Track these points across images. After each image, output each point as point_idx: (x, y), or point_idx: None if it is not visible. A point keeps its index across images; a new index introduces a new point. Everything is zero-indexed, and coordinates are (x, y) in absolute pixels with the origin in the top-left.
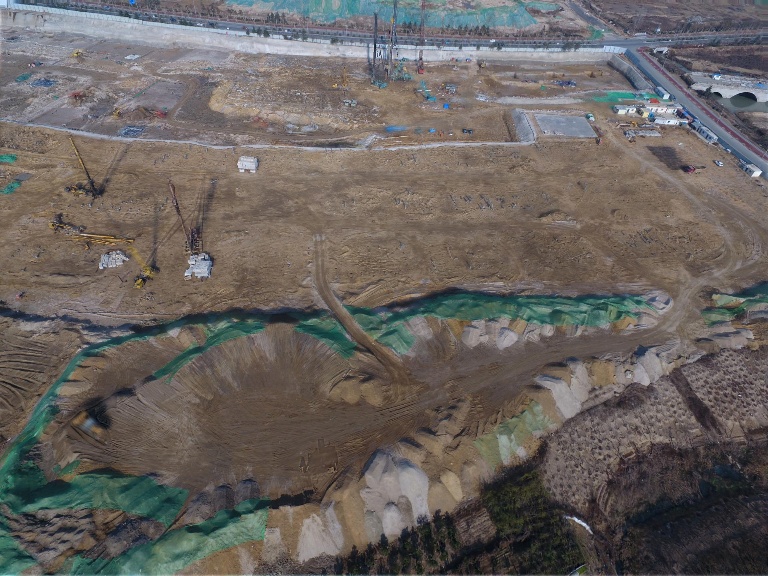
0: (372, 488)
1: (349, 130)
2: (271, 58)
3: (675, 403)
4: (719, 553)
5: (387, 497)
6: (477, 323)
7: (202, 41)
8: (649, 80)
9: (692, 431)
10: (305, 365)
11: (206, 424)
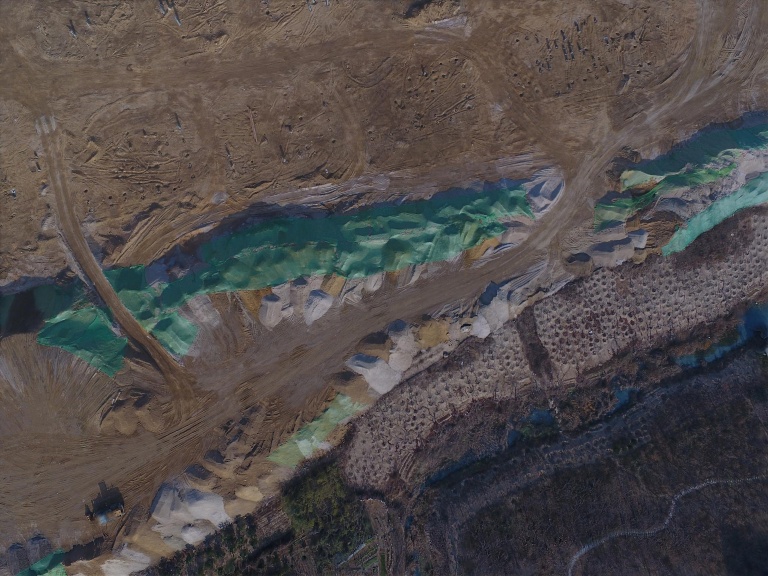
0: (163, 524)
1: None
2: None
3: (512, 354)
4: (497, 510)
5: (182, 522)
6: (278, 291)
7: None
8: None
9: (521, 382)
10: (63, 394)
11: None
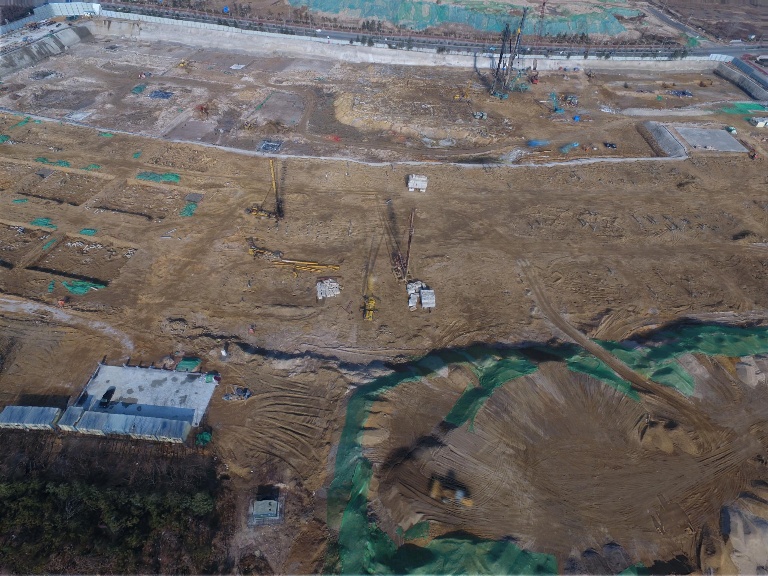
0: (741, 552)
1: (489, 144)
2: (379, 68)
3: None
4: None
5: (754, 561)
6: (747, 360)
7: (303, 50)
8: None
9: None
10: (600, 409)
11: (534, 478)
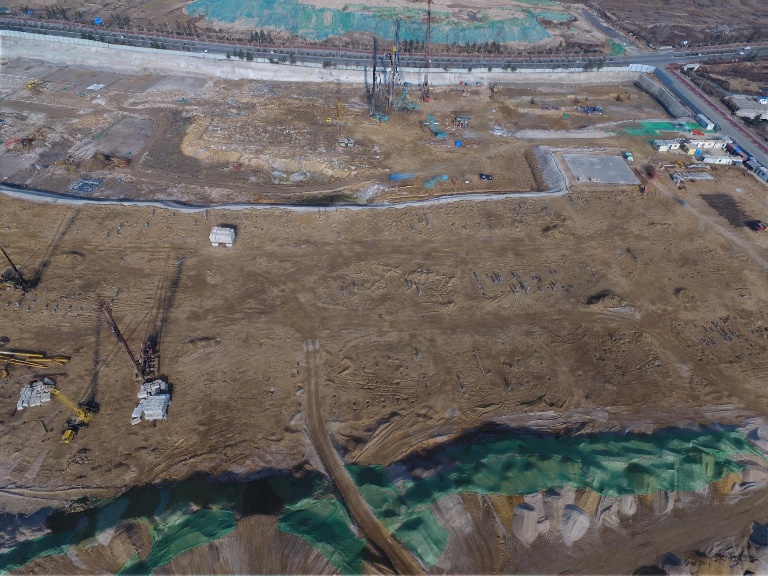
0: None
1: (346, 178)
2: (255, 86)
3: None
4: None
5: None
6: (532, 500)
7: (177, 66)
8: (686, 105)
9: None
10: None
11: None
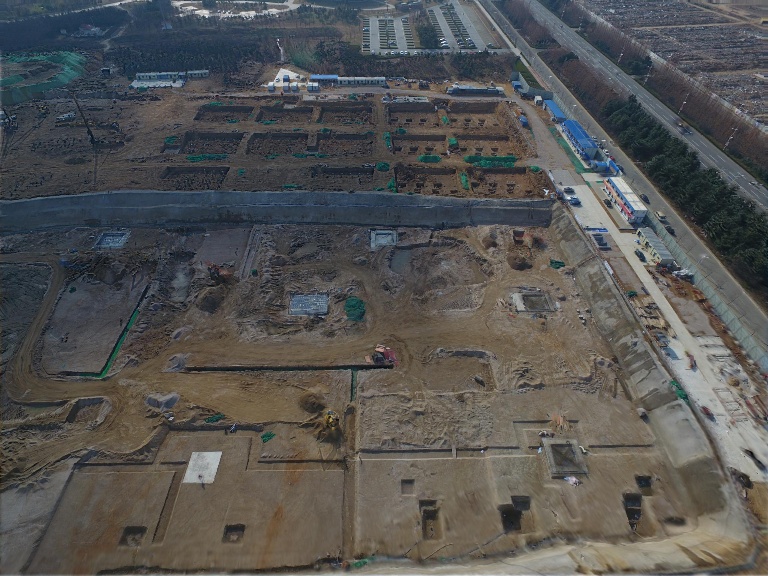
0: None
1: None
2: None
3: None
4: None
5: None
6: None
7: None
8: None
9: None
10: None
11: None
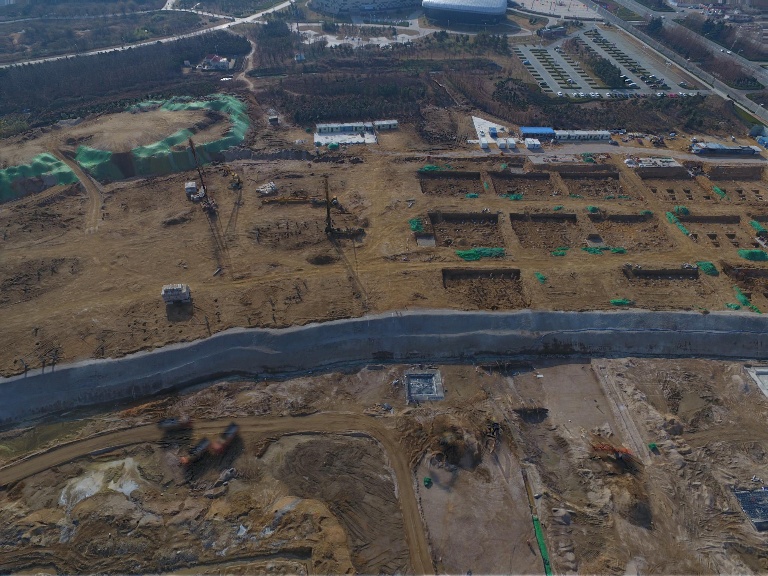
0: None
1: None
2: None
3: None
4: None
5: None
6: None
7: None
8: None
9: None
10: (107, 141)
11: None
